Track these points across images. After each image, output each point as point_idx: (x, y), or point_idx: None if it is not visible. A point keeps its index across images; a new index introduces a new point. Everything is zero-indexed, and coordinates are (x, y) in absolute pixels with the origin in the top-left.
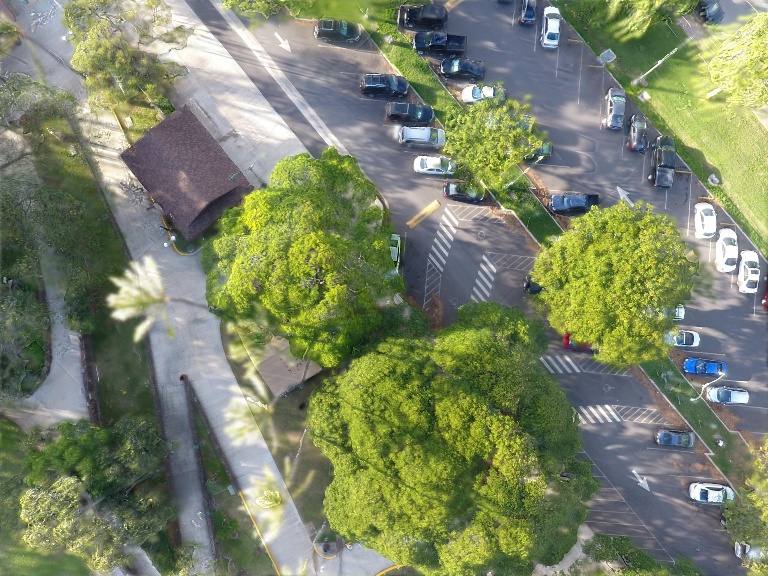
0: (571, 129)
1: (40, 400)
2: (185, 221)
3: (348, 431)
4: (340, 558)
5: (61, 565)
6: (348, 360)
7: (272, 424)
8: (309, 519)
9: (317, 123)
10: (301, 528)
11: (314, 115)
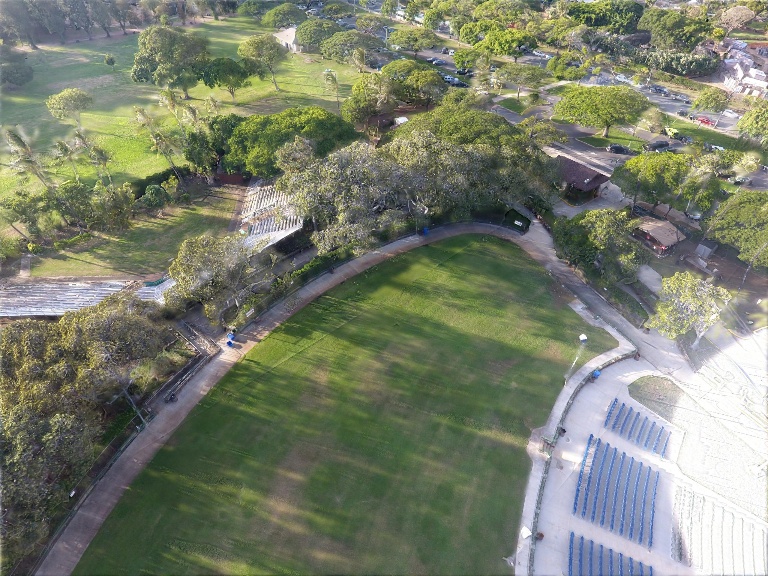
0: (755, 177)
1: (529, 237)
2: (583, 183)
3: (739, 222)
4: (754, 340)
5: (563, 313)
6: (716, 205)
7: (662, 270)
8: None
9: None
10: None
11: None
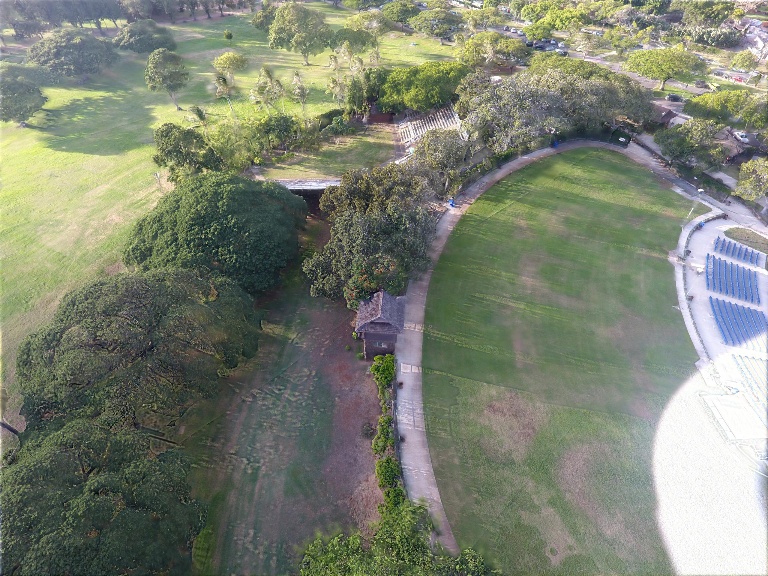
0: None
1: None
2: (659, 117)
3: None
4: None
5: (669, 193)
6: (767, 124)
7: None
8: None
9: (681, 114)
10: None
11: None
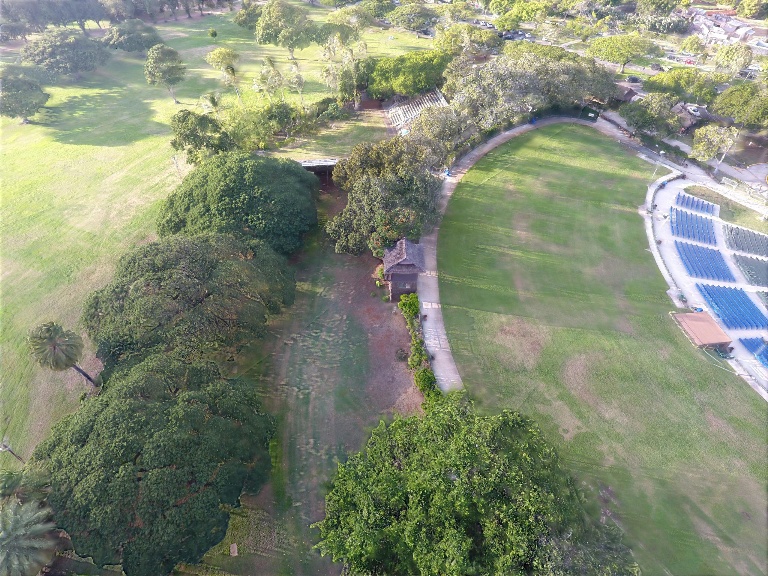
0: None
1: (599, 124)
2: None
3: None
4: (748, 170)
5: None
6: None
7: (685, 141)
8: (723, 161)
9: None
10: (722, 163)
11: (638, 92)
